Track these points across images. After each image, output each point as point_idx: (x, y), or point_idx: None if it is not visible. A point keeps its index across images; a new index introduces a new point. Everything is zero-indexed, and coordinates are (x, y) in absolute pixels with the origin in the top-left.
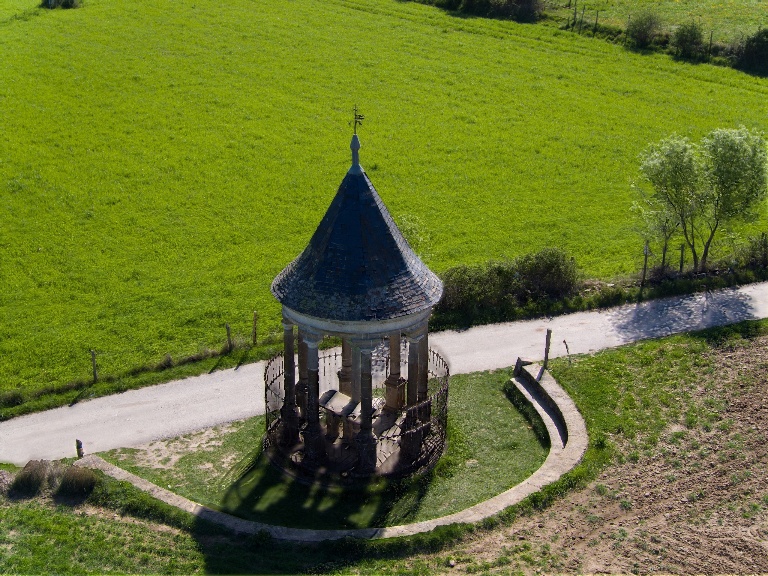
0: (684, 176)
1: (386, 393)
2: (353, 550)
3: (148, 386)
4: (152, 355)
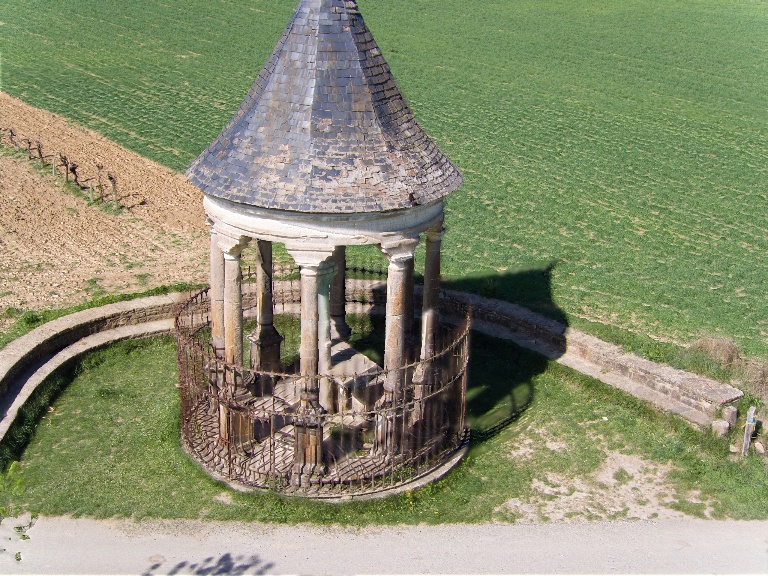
0: None
1: None
2: None
3: None
4: None
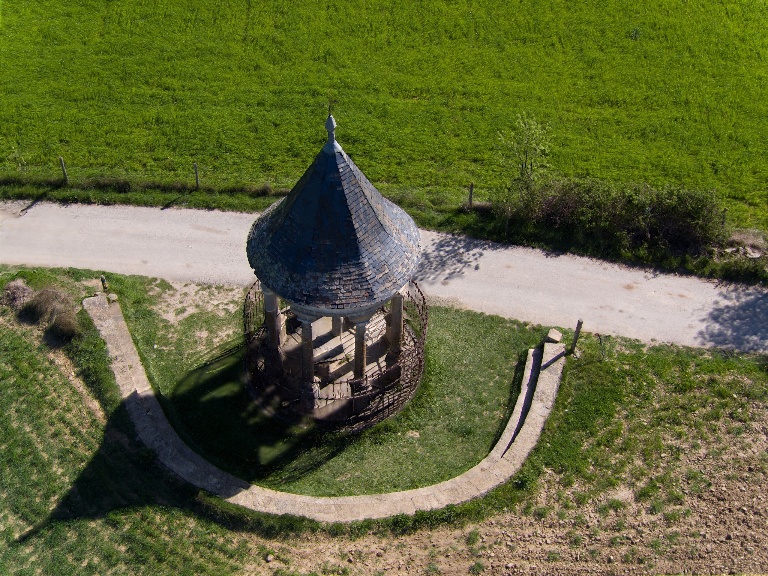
0: None
1: (386, 325)
2: (201, 506)
3: (233, 211)
4: (267, 170)
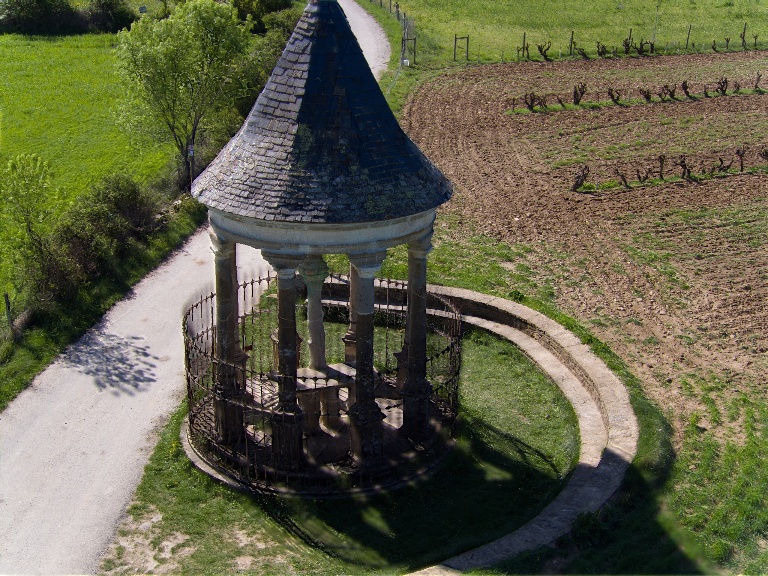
0: (177, 61)
1: None
2: (658, 469)
3: None
4: None
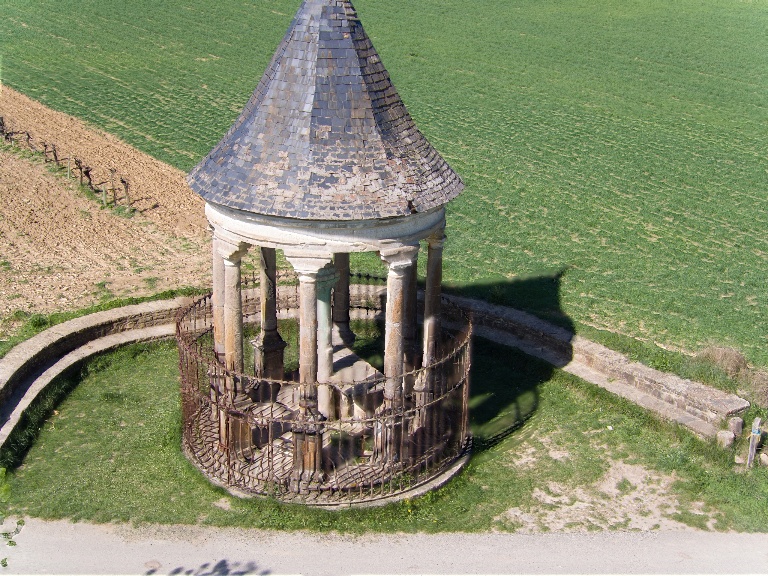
0: None
1: None
2: None
3: None
4: None
